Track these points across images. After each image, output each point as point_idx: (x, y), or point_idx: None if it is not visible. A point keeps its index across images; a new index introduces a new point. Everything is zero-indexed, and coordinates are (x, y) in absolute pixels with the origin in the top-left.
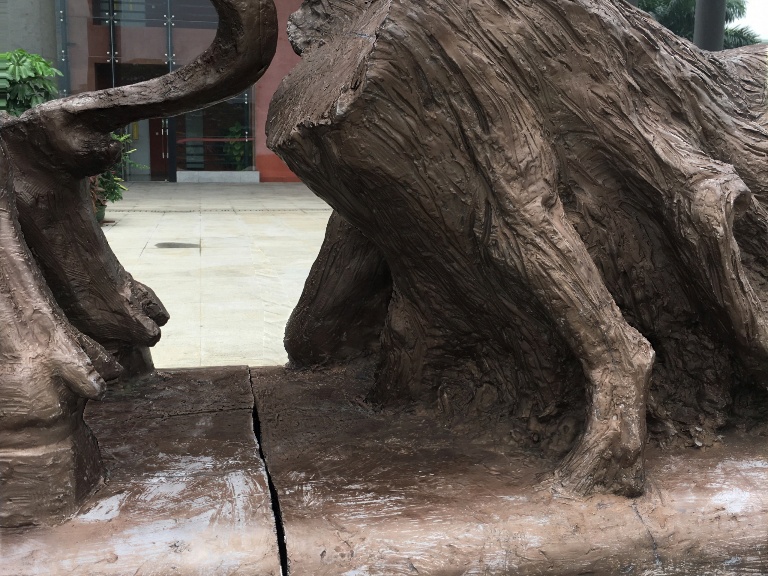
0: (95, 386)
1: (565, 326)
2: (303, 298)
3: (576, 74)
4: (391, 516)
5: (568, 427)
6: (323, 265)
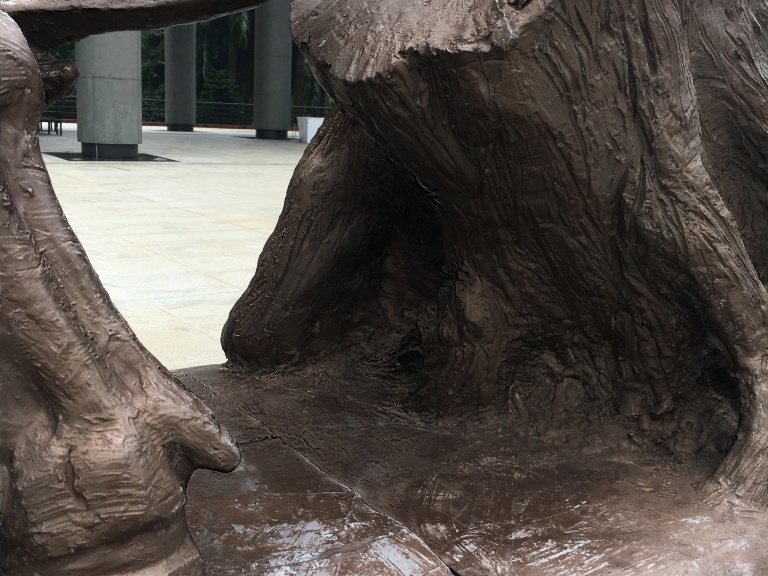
0: (235, 451)
1: (725, 308)
2: (261, 281)
3: (715, 8)
4: (601, 570)
5: (691, 423)
6: (291, 238)
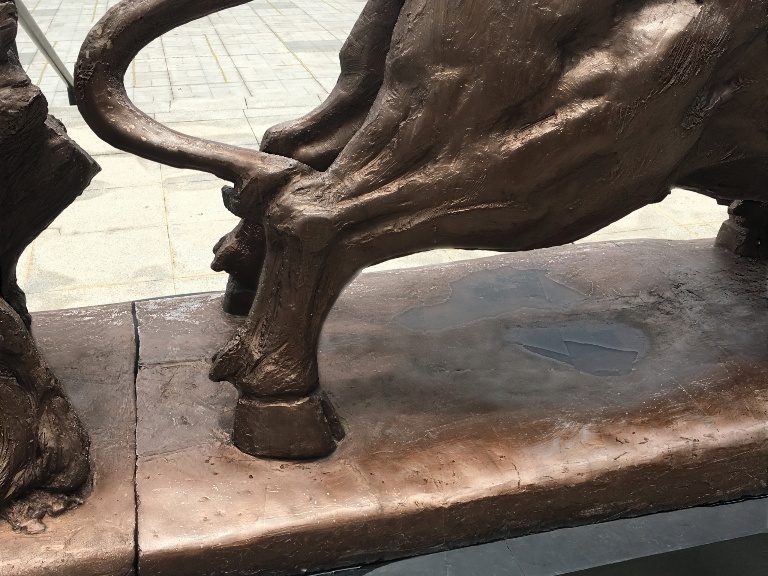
0: None
1: None
2: None
3: None
4: None
5: None
6: None
